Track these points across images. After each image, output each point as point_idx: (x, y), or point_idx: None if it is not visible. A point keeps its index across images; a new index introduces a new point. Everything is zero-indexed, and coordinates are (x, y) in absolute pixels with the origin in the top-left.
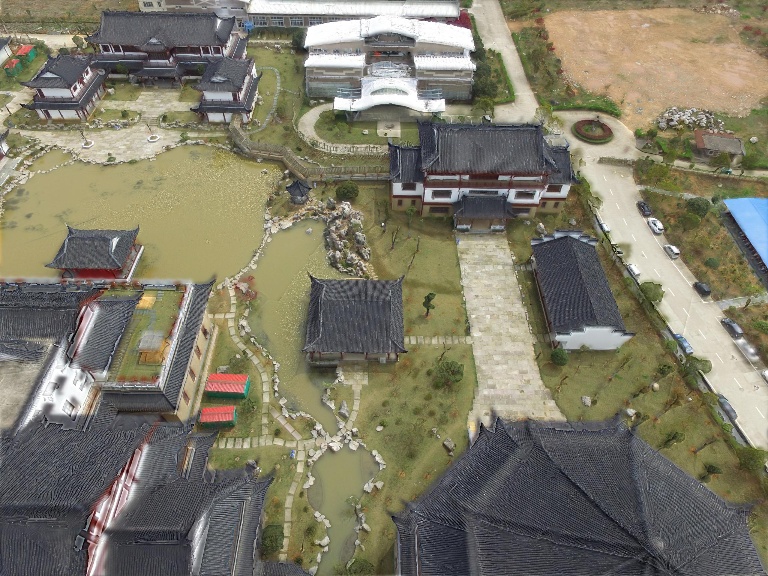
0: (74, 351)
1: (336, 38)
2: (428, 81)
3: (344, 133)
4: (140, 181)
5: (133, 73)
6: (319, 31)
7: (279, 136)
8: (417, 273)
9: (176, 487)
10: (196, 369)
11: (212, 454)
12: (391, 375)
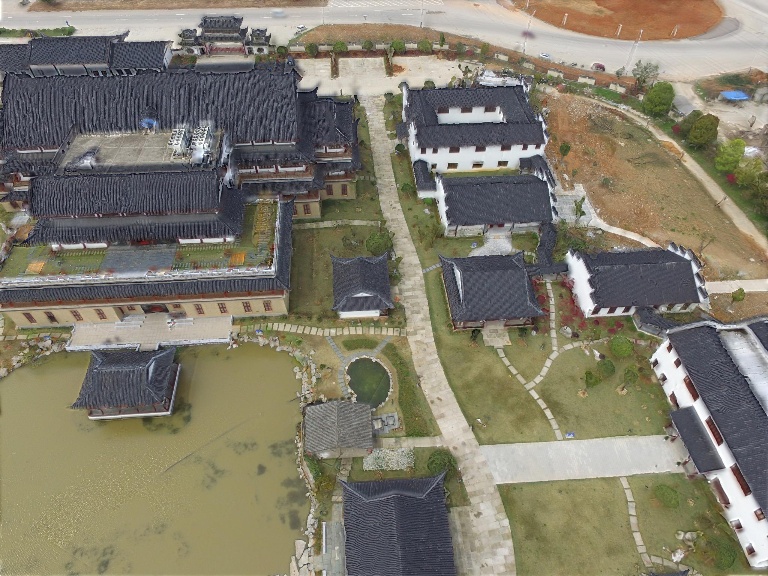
0: None
1: None
2: None
3: None
4: (103, 570)
5: None
6: None
7: None
8: None
9: (6, 150)
10: None
11: None
12: None
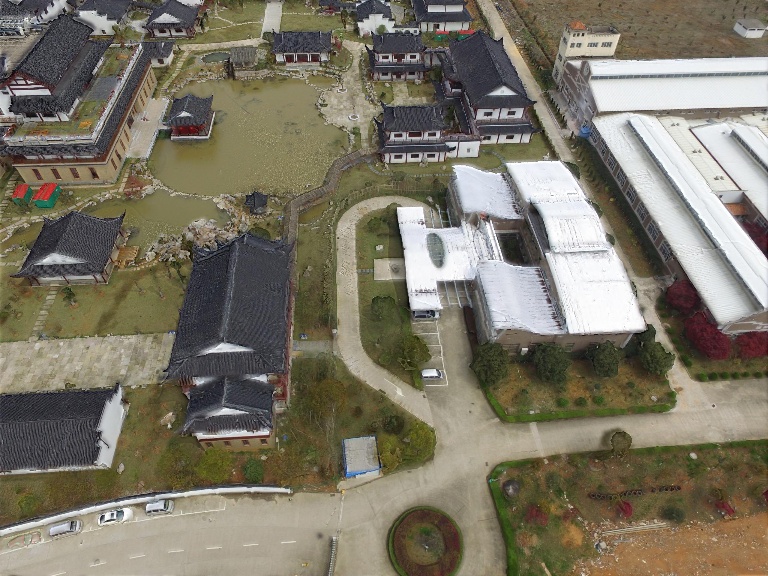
0: (20, 95)
1: (524, 180)
2: (478, 286)
3: (376, 231)
4: (295, 123)
5: (432, 80)
6: (545, 167)
7: None
8: (133, 298)
9: None
10: (65, 177)
11: (0, 198)
12: (19, 283)
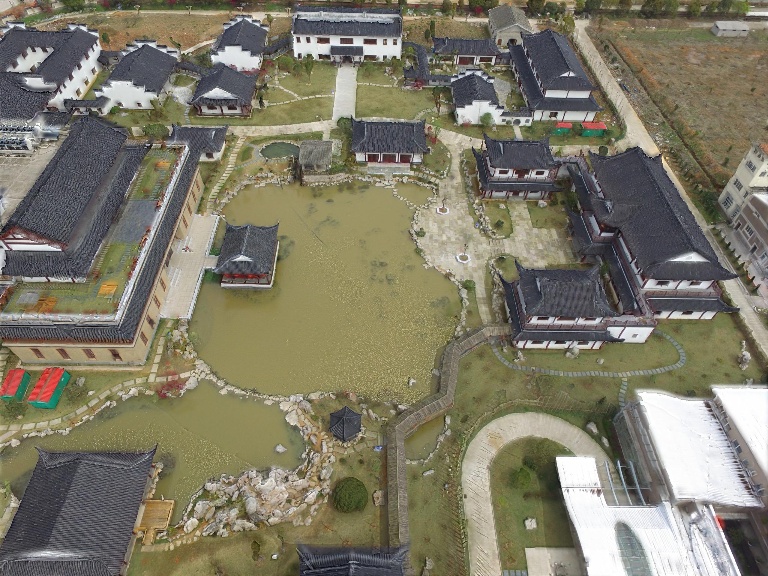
0: (19, 249)
1: (760, 438)
2: None
3: None
4: (385, 263)
5: None
6: None
7: (494, 389)
8: None
9: None
10: (75, 357)
11: None
12: None
